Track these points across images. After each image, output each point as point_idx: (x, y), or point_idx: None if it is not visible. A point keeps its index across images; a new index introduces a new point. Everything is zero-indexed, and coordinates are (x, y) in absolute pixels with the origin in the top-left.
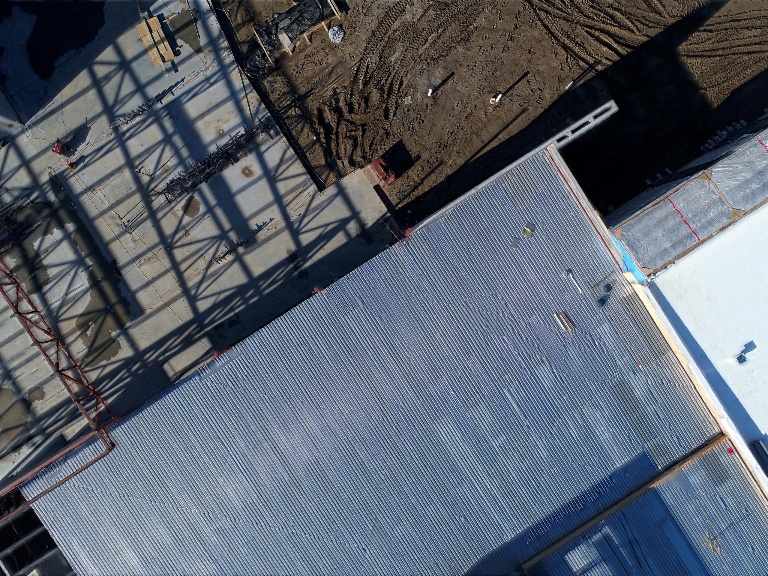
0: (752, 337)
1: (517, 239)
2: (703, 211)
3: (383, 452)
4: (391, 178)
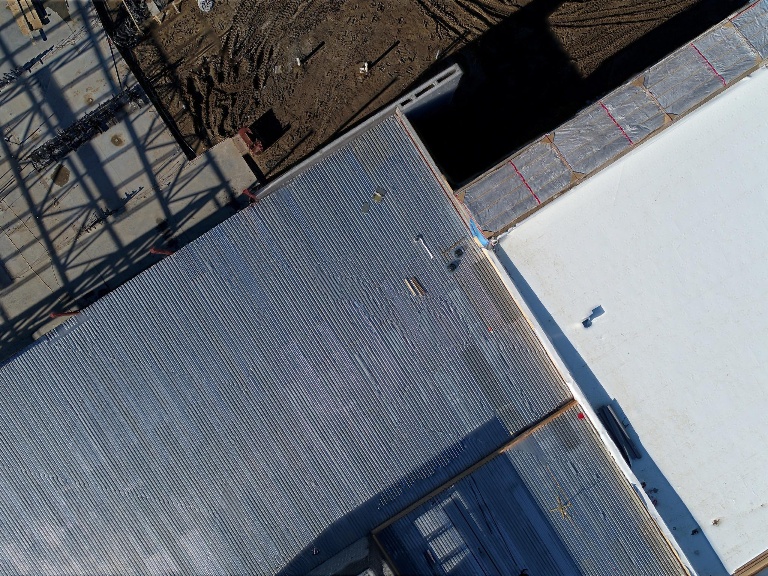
0: (600, 302)
1: (367, 204)
2: (544, 174)
3: (233, 417)
4: (258, 147)
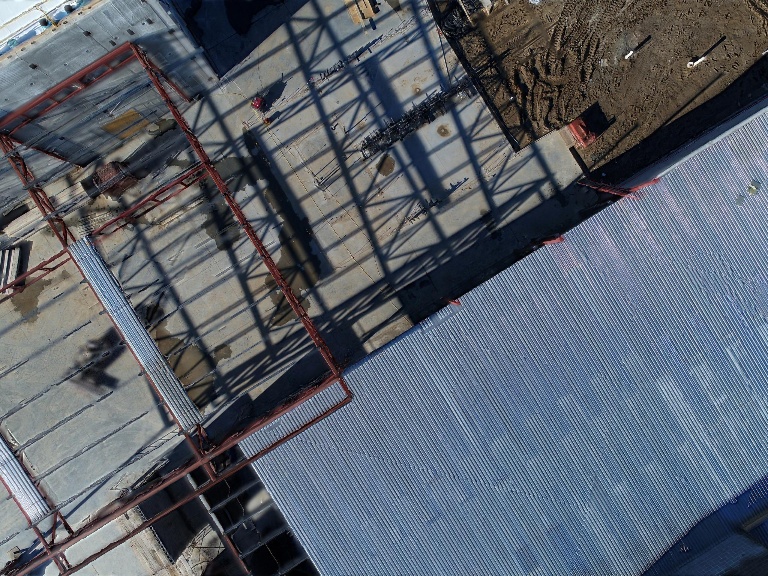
0: None
1: (742, 197)
2: None
3: (604, 410)
4: (591, 139)
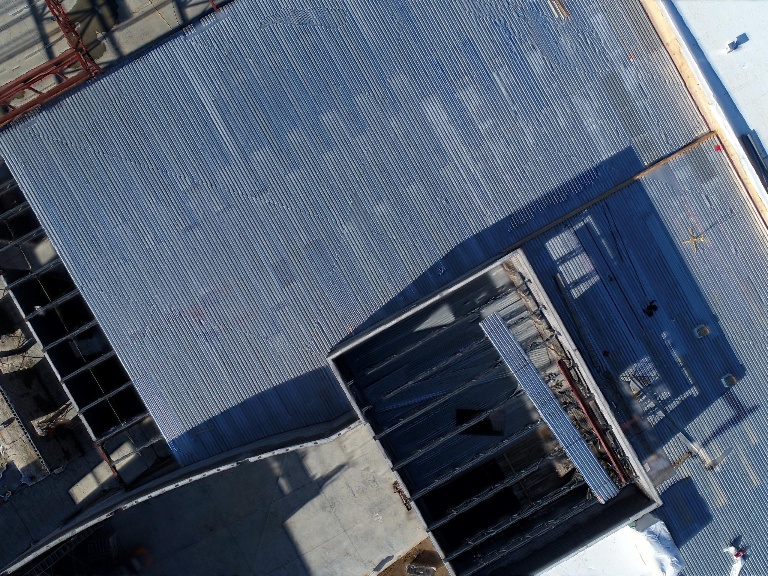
0: (745, 29)
1: None
2: None
3: (367, 127)
4: None
